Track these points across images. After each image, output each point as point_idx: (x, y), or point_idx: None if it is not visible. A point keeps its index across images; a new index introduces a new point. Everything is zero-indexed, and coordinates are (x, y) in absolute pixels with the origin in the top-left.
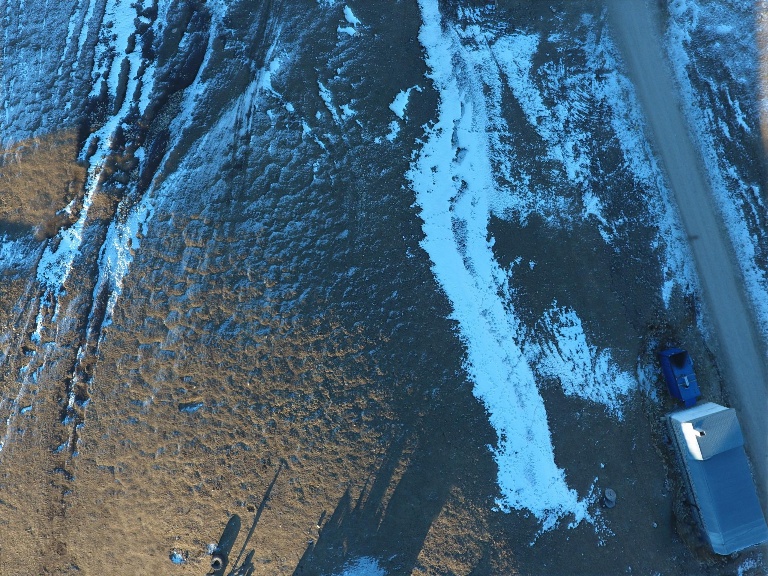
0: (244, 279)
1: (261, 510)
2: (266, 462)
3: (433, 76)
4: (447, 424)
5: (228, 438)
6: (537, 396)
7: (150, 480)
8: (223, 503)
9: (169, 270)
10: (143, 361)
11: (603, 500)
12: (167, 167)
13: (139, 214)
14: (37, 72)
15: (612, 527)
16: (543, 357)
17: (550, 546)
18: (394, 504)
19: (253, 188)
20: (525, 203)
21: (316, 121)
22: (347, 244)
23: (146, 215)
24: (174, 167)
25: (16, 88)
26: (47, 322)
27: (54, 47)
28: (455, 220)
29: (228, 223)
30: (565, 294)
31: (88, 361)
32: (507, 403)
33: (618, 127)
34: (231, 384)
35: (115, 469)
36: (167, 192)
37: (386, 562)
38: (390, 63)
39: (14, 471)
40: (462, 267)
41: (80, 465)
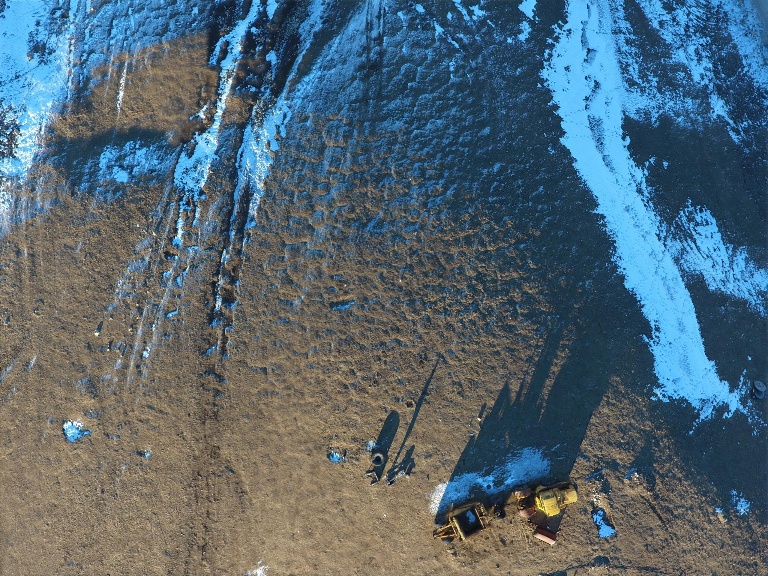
0: (389, 177)
1: (420, 405)
2: (423, 357)
3: None
4: (602, 315)
5: (382, 335)
6: (684, 289)
7: (304, 379)
8: (380, 399)
9: (311, 170)
10: (291, 261)
11: (753, 391)
12: (300, 70)
13: (275, 117)
14: None
15: (763, 418)
16: (685, 253)
17: (708, 434)
18: (554, 394)
19: (390, 88)
20: (655, 104)
21: (448, 22)
22: (490, 141)
23: (283, 117)
24: (308, 69)
25: None
26: (188, 226)
27: None
28: (591, 119)
29: (368, 122)
30: (699, 194)
31: (234, 263)
32: (657, 295)
33: (735, 33)
34: (383, 281)
35: (267, 370)
36: (303, 94)
37: (549, 452)
38: None
39: (163, 376)
40: (602, 164)
41: (231, 367)
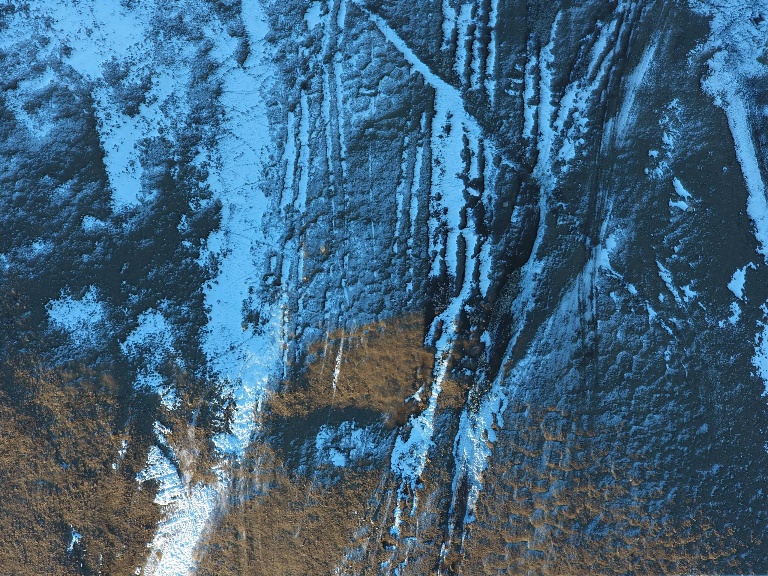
0: (608, 476)
1: None
2: None
3: (764, 251)
4: None
5: None
6: None
7: None
8: None
9: (531, 465)
10: (511, 561)
11: None
12: (515, 353)
13: (492, 403)
14: (372, 249)
15: None
16: None
17: None
18: None
19: (607, 378)
20: None
21: (660, 304)
22: (708, 439)
23: (499, 405)
24: (523, 353)
25: (352, 266)
26: (406, 516)
27: (385, 221)
28: None
29: (586, 416)
30: None
31: (453, 559)
32: None
33: None
34: None
35: None
36: (519, 381)
37: None
38: (724, 239)
39: None
40: None
41: None
